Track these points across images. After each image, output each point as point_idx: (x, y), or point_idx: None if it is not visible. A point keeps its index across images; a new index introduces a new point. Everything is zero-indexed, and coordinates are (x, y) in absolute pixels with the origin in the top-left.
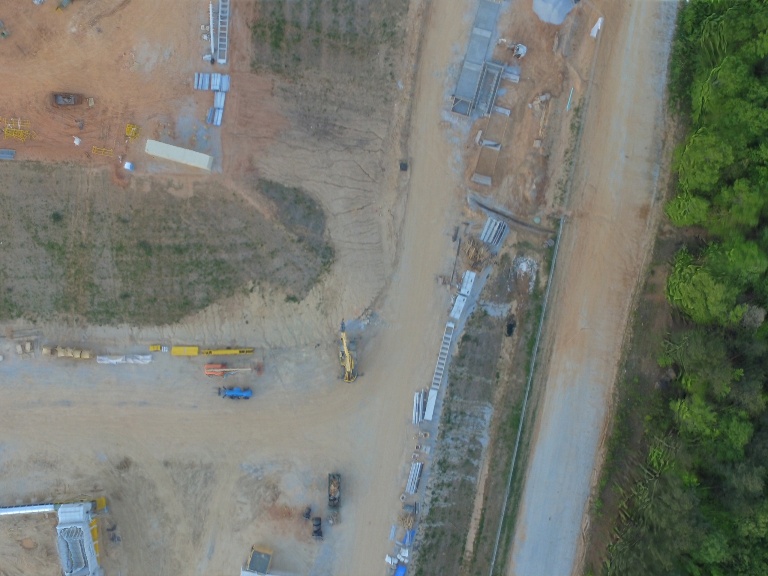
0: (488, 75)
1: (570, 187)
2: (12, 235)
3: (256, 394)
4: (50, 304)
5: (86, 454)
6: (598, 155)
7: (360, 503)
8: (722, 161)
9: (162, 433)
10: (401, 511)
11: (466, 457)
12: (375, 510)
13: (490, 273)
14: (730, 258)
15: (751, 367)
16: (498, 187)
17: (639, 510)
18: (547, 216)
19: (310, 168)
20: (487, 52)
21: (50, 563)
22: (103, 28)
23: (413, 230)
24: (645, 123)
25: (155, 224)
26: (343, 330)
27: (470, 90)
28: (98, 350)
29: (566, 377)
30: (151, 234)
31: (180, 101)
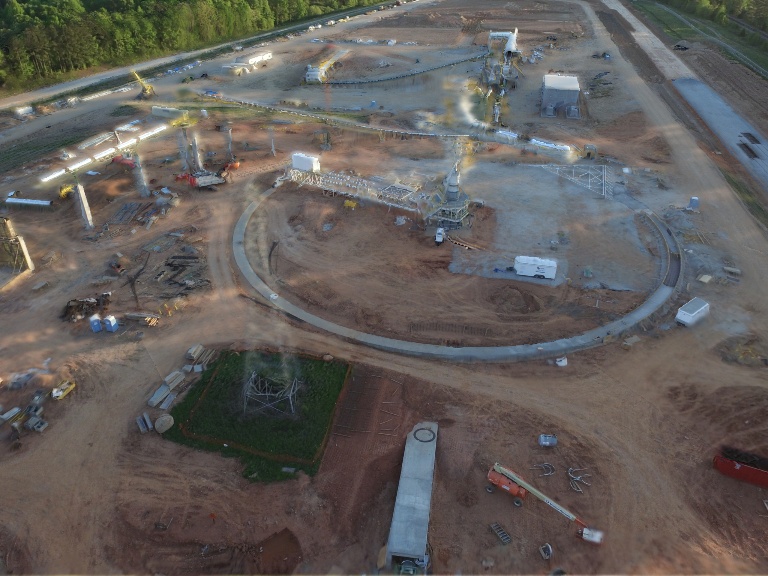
0: None
1: None
2: None
3: None
4: None
5: None
6: None
7: None
8: None
9: None
10: None
11: None
12: None
13: None
14: None
15: None
16: None
17: None
18: None
19: None
20: None
21: None
22: None
23: None
24: None
25: None
26: None
27: None
28: None
29: (46, 95)
30: None
31: (154, 127)
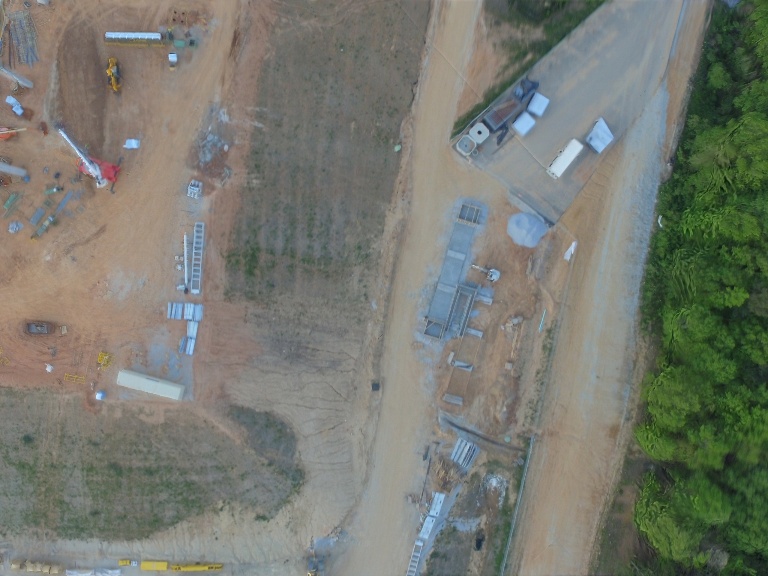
0: (461, 297)
1: (541, 407)
2: None
3: None
4: (20, 519)
5: None
6: (569, 376)
7: None
8: (688, 409)
9: None
10: None
11: None
12: None
13: (460, 492)
14: (694, 505)
15: None
16: (469, 407)
17: None
18: (517, 435)
19: (282, 391)
20: (461, 274)
21: None
22: (77, 257)
23: (384, 449)
24: (616, 344)
25: (126, 447)
26: (312, 547)
27: (443, 312)
28: (67, 564)
29: None
30: (122, 456)
31: (153, 330)
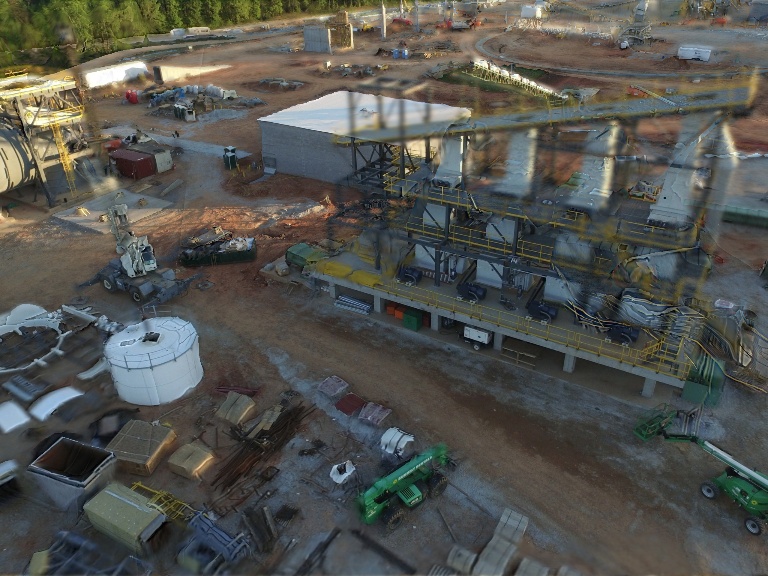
0: None
1: None
2: None
3: None
4: None
5: None
6: (267, 25)
7: None
8: None
9: None
10: None
11: None
12: None
13: None
14: None
15: None
16: None
17: None
18: None
19: None
20: None
21: None
22: None
23: None
24: None
25: None
26: None
27: None
28: None
29: None
30: None
31: None
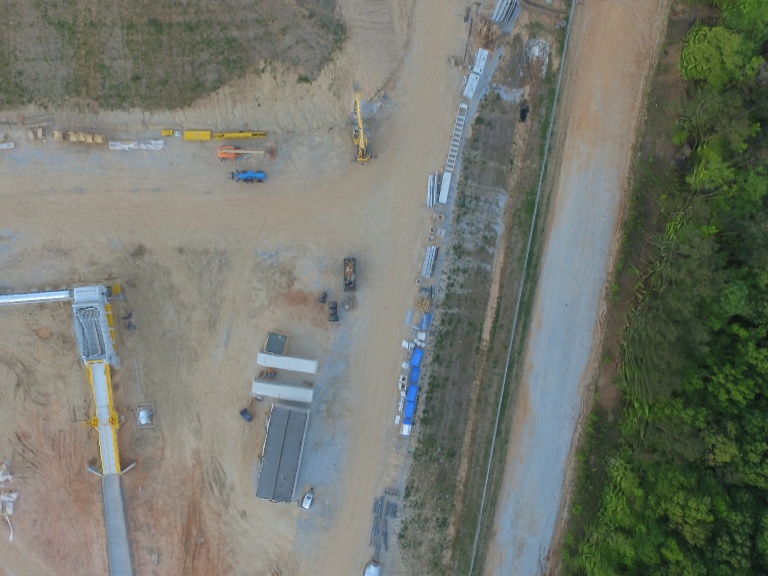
0: None
1: None
2: (22, 14)
3: (269, 178)
4: (61, 88)
5: (100, 242)
6: None
7: (376, 288)
8: None
9: (176, 220)
10: (417, 296)
11: (481, 244)
12: (391, 295)
13: (502, 54)
14: (745, 10)
15: (767, 121)
16: None
17: (657, 277)
18: None
19: None
20: None
21: (66, 352)
22: None
23: (424, 11)
24: None
25: None
26: None
27: None
28: (110, 136)
29: (580, 161)
30: (161, 11)
31: None
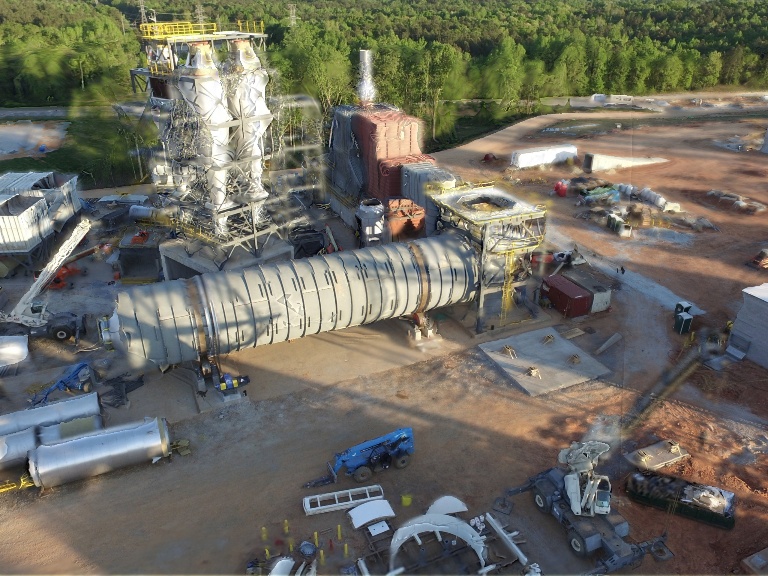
0: None
1: None
2: None
3: None
4: None
5: None
6: None
7: None
8: None
9: None
10: None
11: None
12: None
13: None
14: None
15: None
16: None
17: None
18: None
19: None
20: None
21: None
22: None
23: None
24: None
25: None
26: None
27: (732, 107)
28: None
29: None
30: None
31: None
